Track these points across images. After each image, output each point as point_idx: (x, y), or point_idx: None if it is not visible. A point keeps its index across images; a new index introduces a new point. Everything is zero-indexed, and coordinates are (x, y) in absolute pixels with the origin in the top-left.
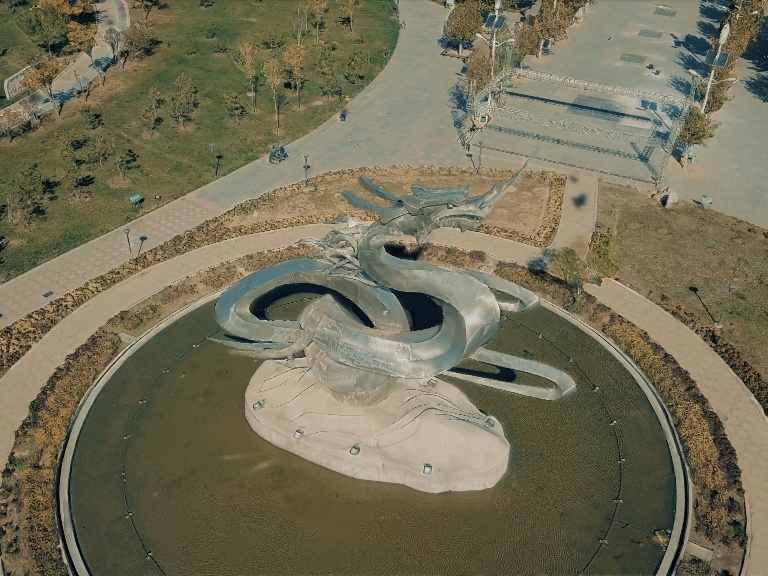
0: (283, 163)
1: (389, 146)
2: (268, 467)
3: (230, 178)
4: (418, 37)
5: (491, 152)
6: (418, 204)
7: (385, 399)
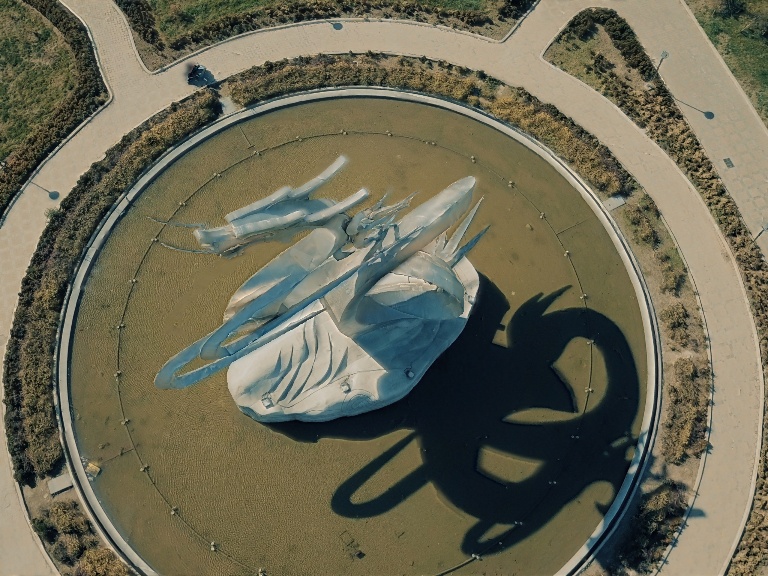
0: None
1: None
2: None
3: None
4: None
5: None
6: None
7: None
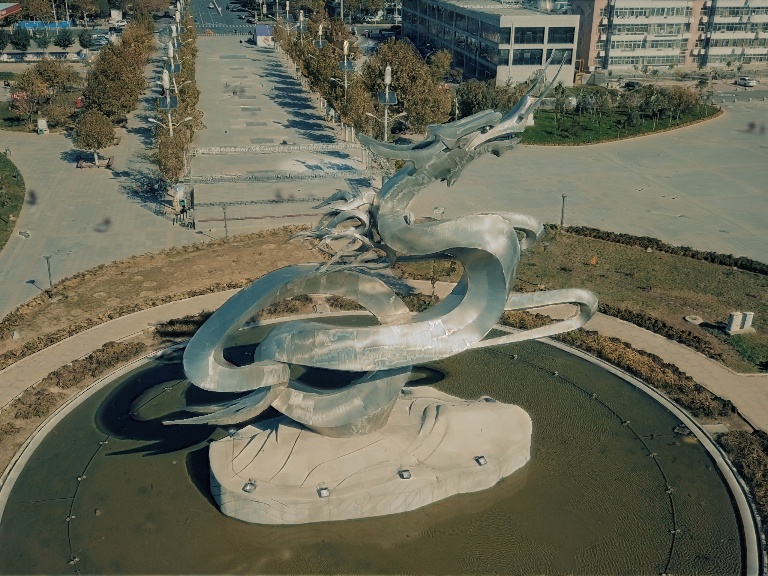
0: None
1: (107, 244)
2: (307, 548)
3: None
4: (35, 159)
5: (220, 224)
6: (455, 135)
7: (389, 416)
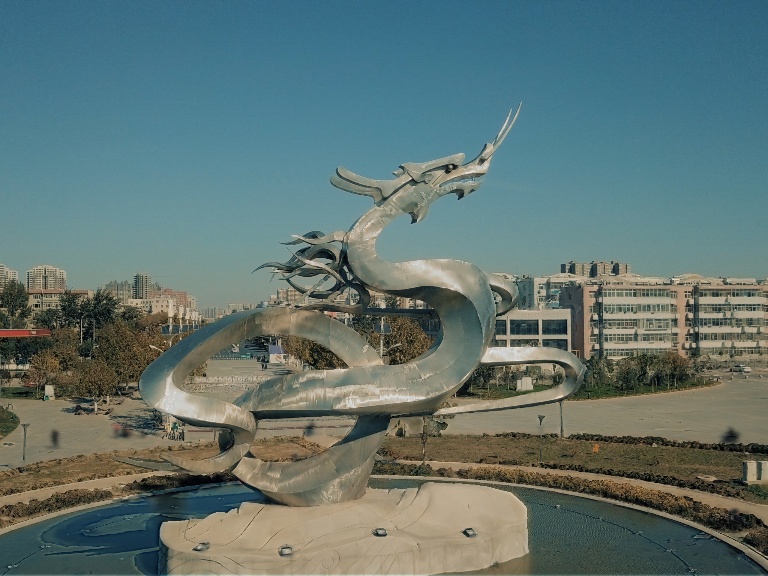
0: None
1: (91, 448)
2: None
3: None
4: (35, 411)
5: (210, 435)
6: (420, 168)
7: (365, 493)
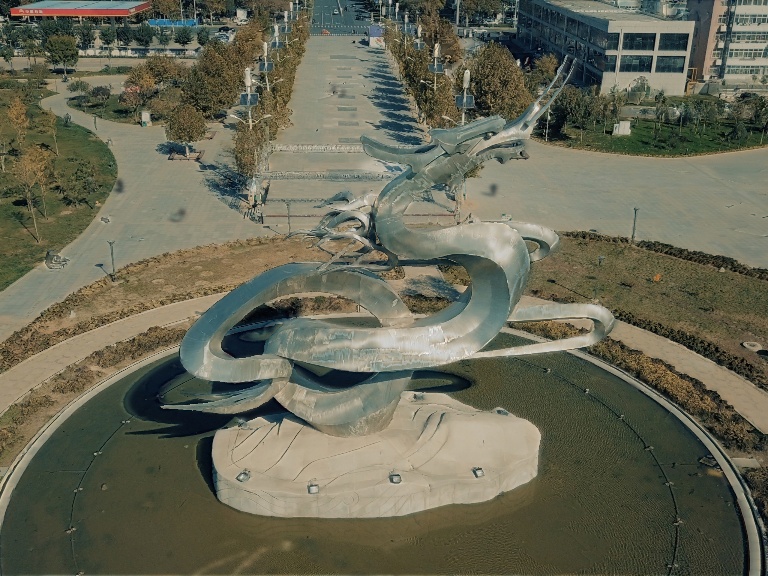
0: (67, 267)
1: (177, 234)
2: (290, 542)
3: (12, 291)
4: (133, 150)
5: None
6: (455, 140)
7: (392, 420)
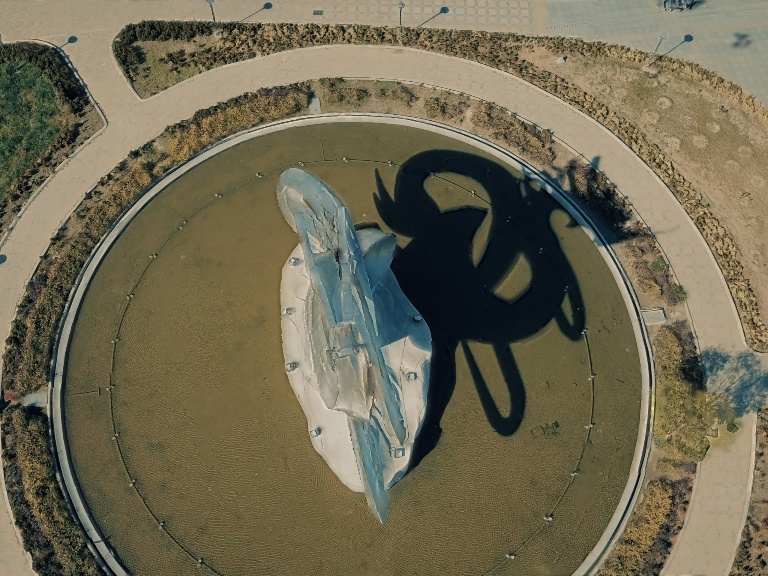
0: (674, 14)
1: None
2: (259, 310)
3: None
4: None
5: None
6: None
7: None
